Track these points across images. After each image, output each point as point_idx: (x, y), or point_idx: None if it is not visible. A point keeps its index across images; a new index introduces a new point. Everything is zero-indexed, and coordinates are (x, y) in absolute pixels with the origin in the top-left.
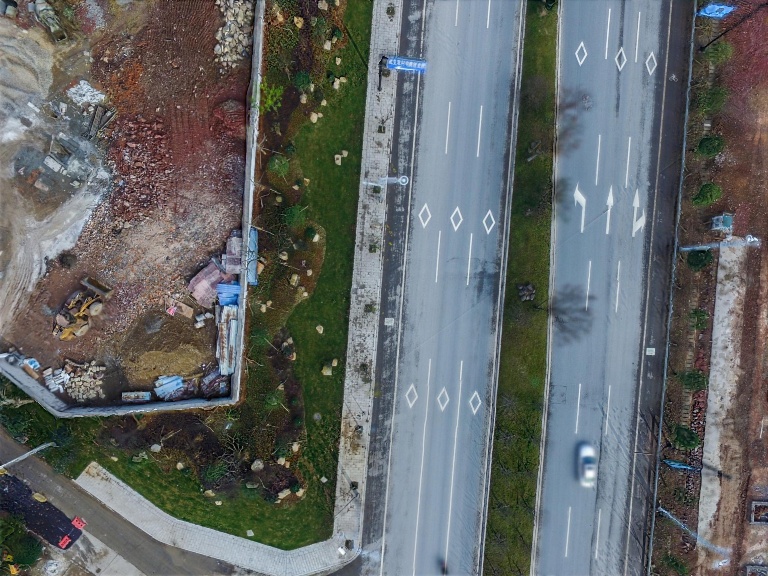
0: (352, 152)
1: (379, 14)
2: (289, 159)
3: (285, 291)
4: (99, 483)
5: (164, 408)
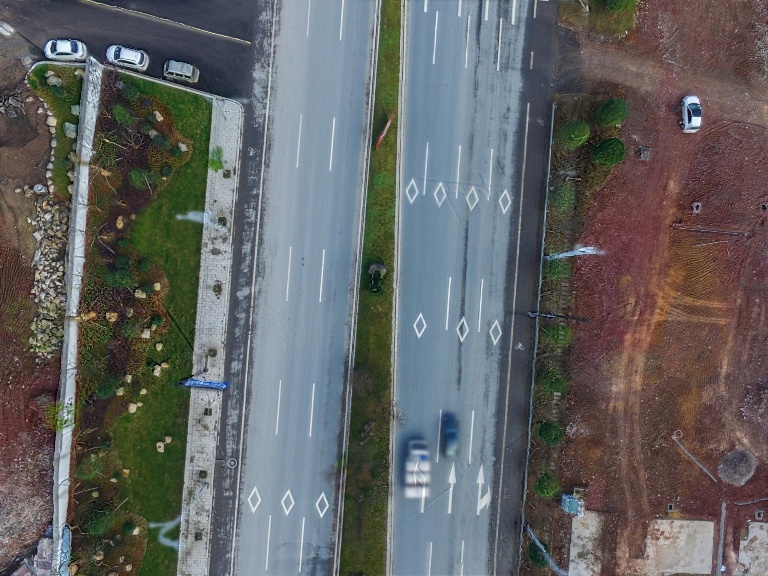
0: (177, 436)
1: (205, 292)
2: (106, 452)
3: None
4: None
5: None
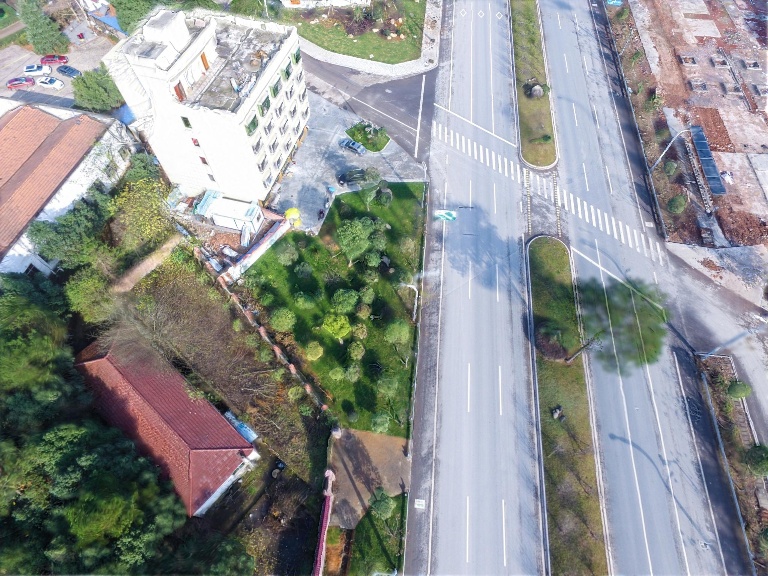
0: None
1: None
2: None
3: None
4: None
5: None
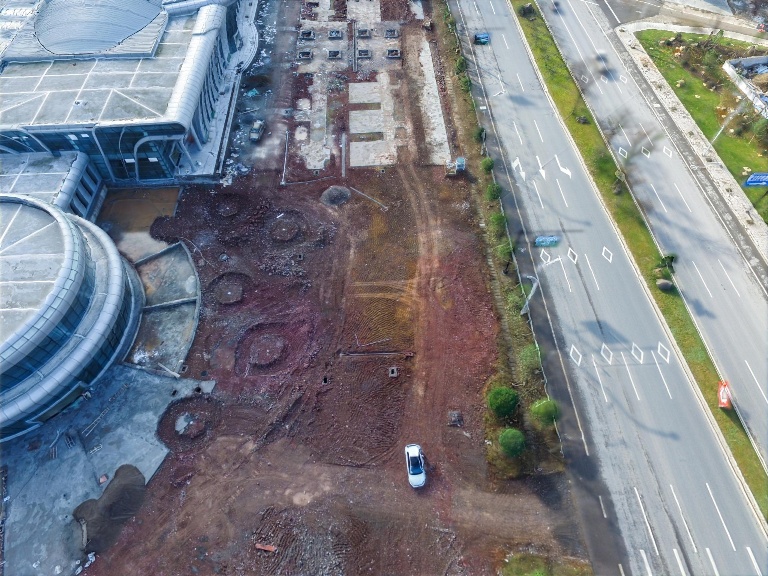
0: (740, 176)
1: None
2: None
3: (732, 106)
4: (764, 42)
5: (762, 56)
